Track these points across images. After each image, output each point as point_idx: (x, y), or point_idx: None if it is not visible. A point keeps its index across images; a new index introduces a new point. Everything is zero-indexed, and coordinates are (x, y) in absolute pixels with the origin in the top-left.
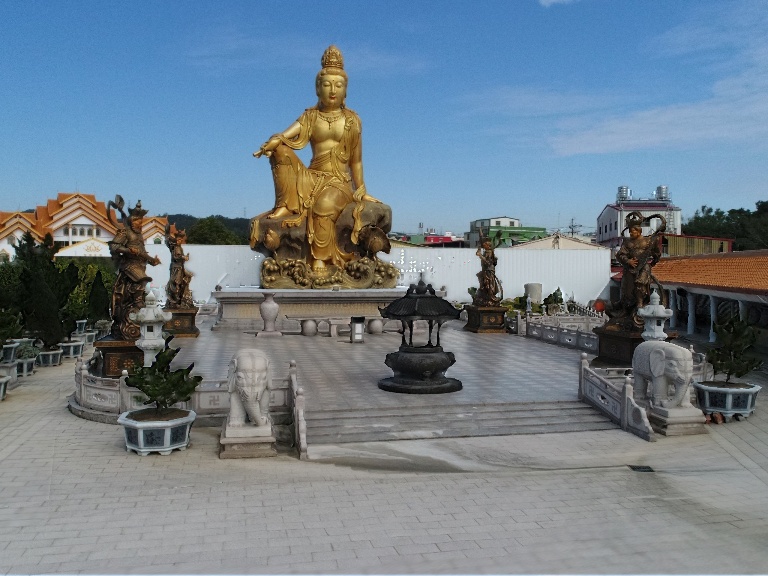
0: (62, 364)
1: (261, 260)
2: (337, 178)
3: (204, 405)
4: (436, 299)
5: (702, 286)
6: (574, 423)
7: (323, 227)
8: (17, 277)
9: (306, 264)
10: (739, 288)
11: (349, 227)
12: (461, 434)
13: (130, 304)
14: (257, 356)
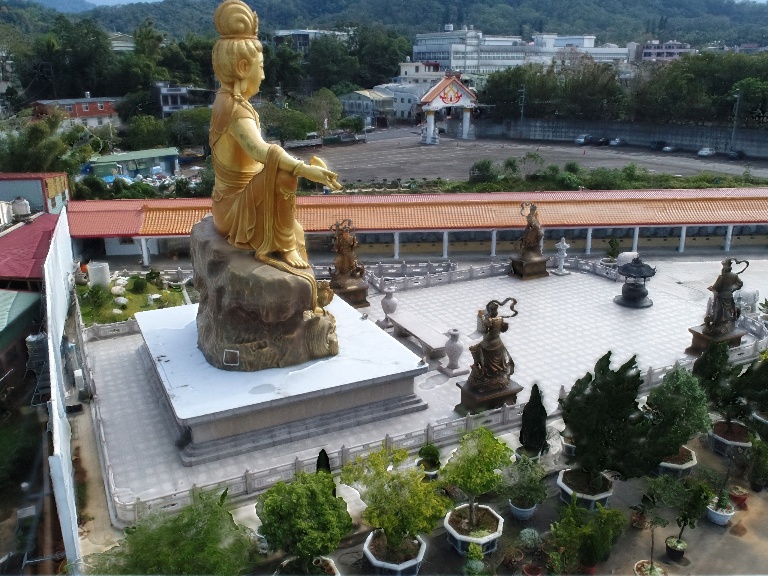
0: None
1: None
2: None
3: None
4: None
5: (416, 228)
6: None
7: None
8: None
9: None
10: (479, 226)
11: None
12: None
13: None
14: None
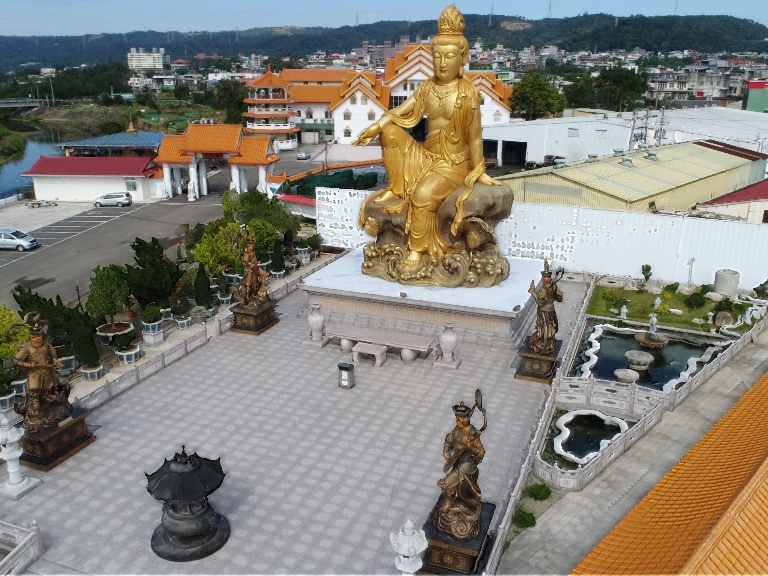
0: (102, 377)
1: None
2: (445, 161)
3: None
4: (184, 477)
5: None
6: None
7: (418, 218)
8: (105, 289)
9: (405, 252)
10: None
11: (451, 216)
12: None
13: None
14: None
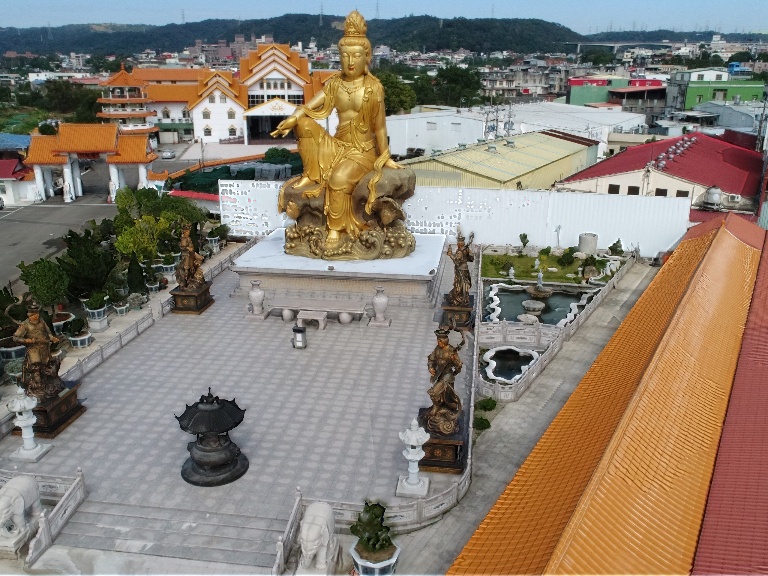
0: (62, 361)
1: None
2: (356, 149)
3: None
4: (214, 413)
5: None
6: (254, 553)
7: (336, 201)
8: (48, 279)
9: (324, 231)
10: None
11: (365, 197)
12: (158, 553)
13: None
14: (5, 496)
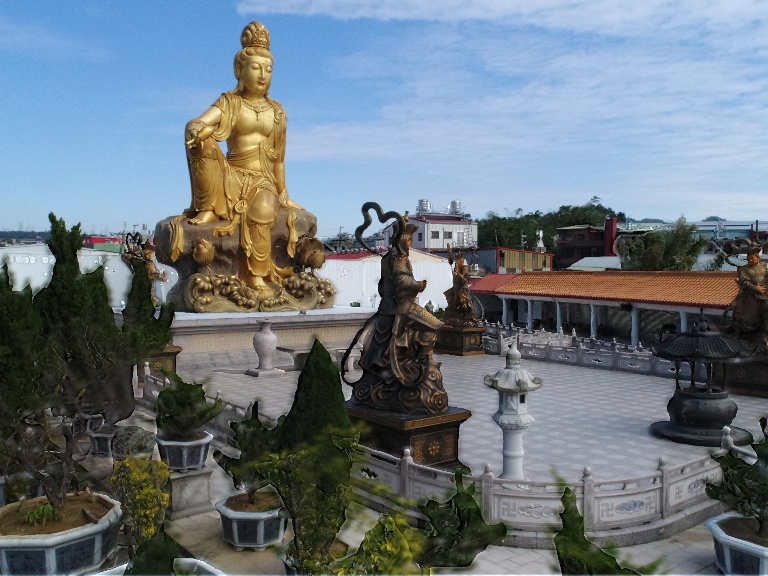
0: None
1: (120, 273)
2: (267, 179)
3: (671, 501)
4: None
5: (690, 304)
6: None
7: (263, 237)
8: None
9: (240, 281)
10: None
11: (283, 237)
12: None
13: (409, 361)
14: None
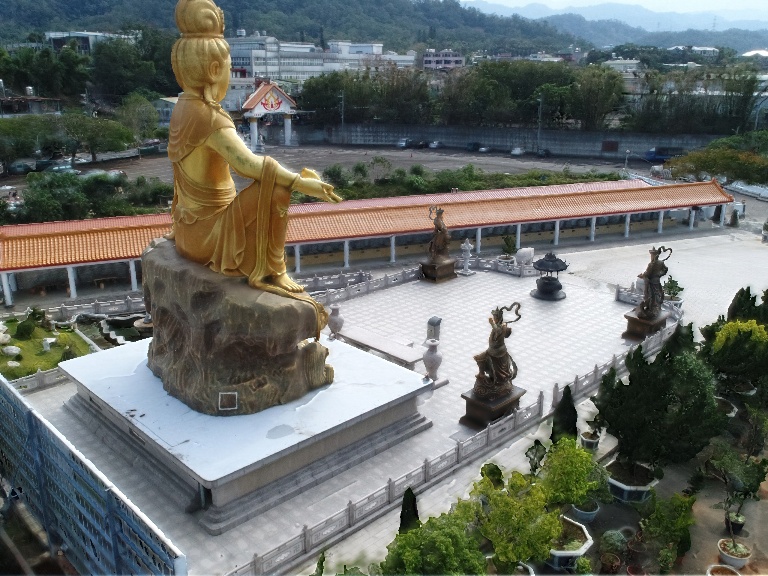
0: None
1: None
2: None
3: None
4: None
5: (318, 239)
6: None
7: None
8: None
9: None
10: None
11: None
12: None
13: None
14: None
